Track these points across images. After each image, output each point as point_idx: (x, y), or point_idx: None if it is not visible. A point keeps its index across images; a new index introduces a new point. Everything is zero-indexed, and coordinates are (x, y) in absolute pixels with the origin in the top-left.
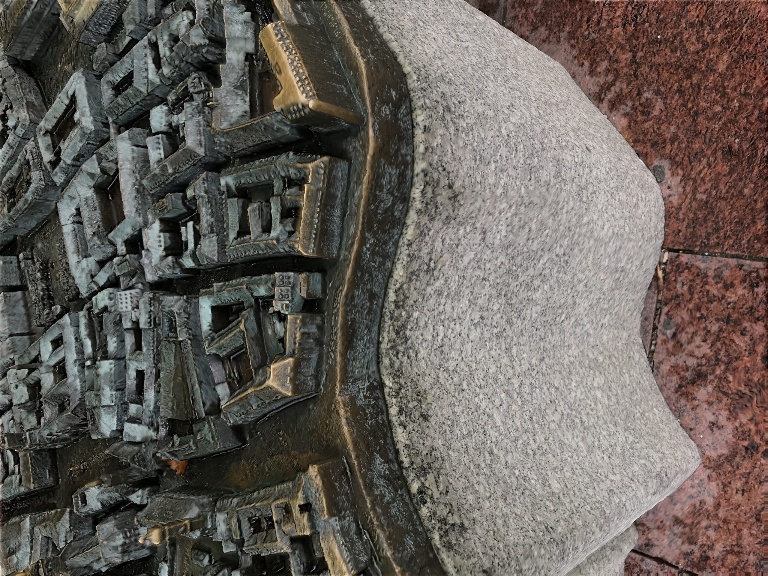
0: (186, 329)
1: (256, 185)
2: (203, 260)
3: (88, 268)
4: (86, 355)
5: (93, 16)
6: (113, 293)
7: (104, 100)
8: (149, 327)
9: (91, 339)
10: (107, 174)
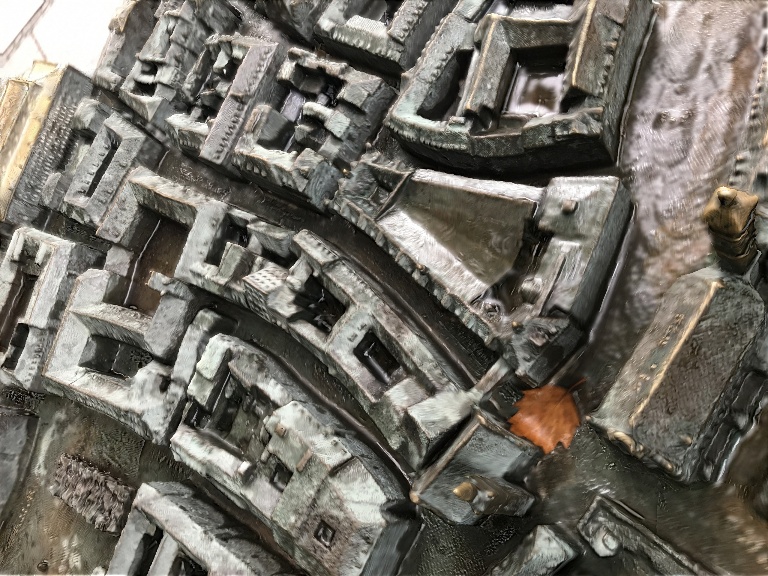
0: (403, 166)
1: (365, 4)
2: (360, 95)
3: (152, 376)
4: (229, 470)
5: (23, 175)
6: (225, 337)
7: (79, 204)
8: (334, 258)
9: (221, 447)
10: (118, 275)
